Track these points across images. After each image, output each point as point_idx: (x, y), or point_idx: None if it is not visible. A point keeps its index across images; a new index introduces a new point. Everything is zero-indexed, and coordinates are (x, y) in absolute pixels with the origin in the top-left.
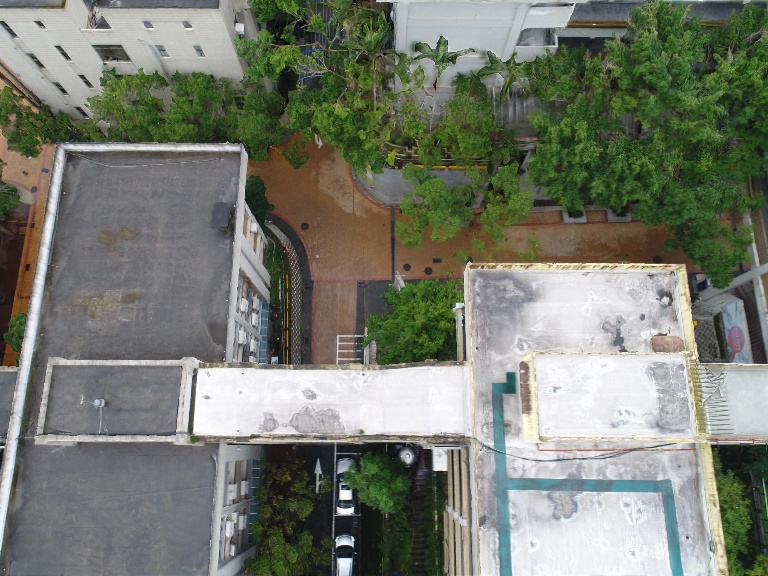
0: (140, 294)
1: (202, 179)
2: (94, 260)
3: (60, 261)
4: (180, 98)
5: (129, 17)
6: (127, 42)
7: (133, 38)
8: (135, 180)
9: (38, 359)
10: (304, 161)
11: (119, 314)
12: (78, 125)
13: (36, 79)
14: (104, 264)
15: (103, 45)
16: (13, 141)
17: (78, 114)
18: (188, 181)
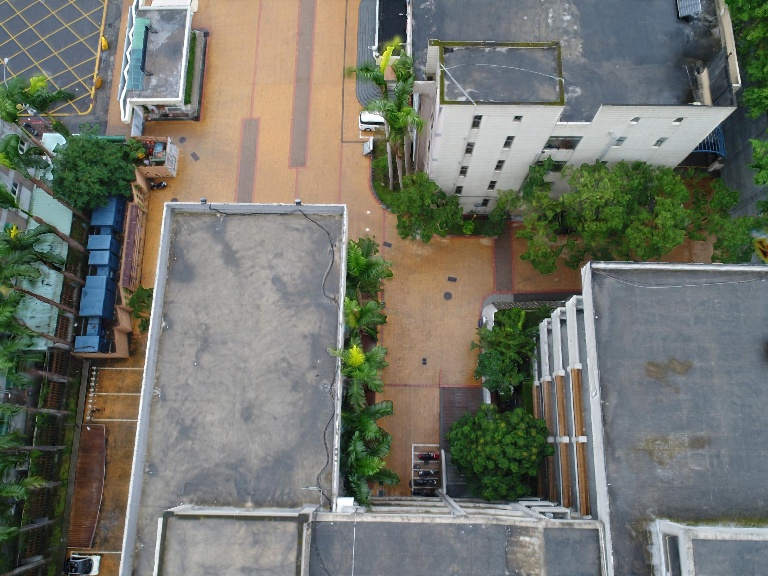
0: (709, 438)
1: (746, 303)
2: (647, 397)
3: (609, 397)
4: (668, 200)
5: (625, 113)
6: (593, 134)
7: (604, 131)
8: (672, 303)
9: (611, 513)
10: (749, 258)
11: (690, 461)
12: (527, 221)
13: (449, 163)
14: (660, 402)
15: (563, 136)
16: (406, 226)
17: (453, 192)
18: (731, 305)
